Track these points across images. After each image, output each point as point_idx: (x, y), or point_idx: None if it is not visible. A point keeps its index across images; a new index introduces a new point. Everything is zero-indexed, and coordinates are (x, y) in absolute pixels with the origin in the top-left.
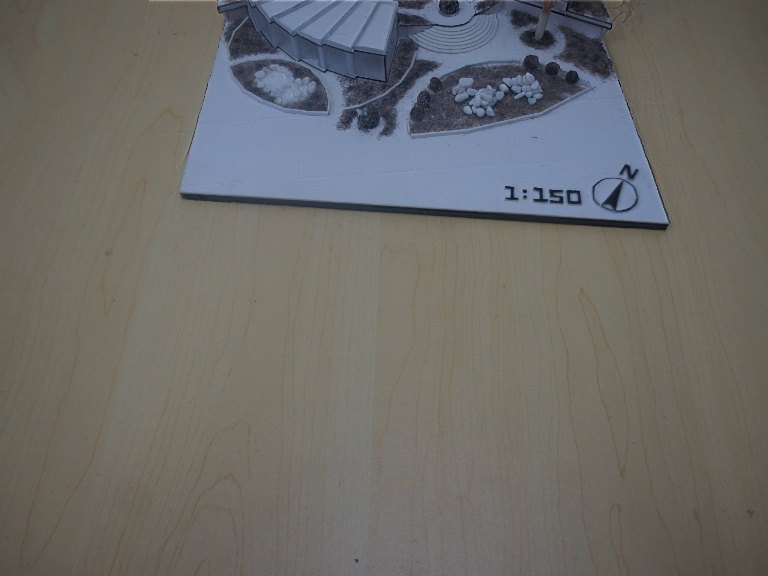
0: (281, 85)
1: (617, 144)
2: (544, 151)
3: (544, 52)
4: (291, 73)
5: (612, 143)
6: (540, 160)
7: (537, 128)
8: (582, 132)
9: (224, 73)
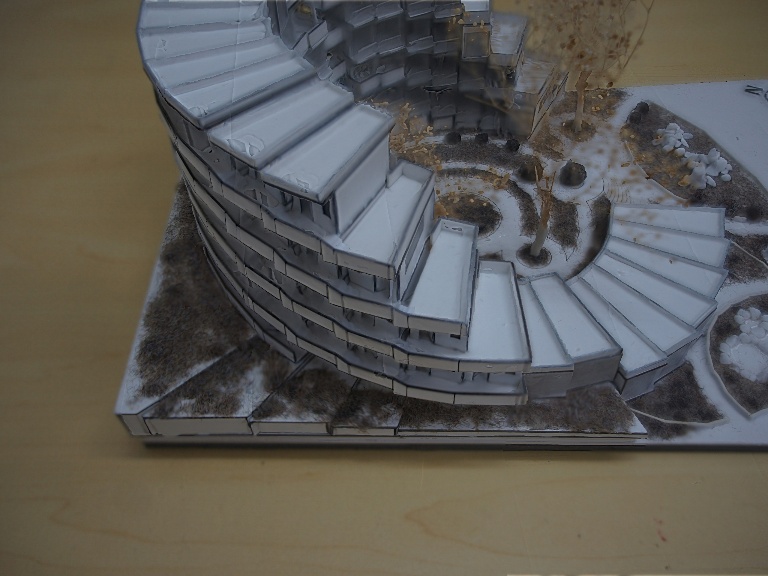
0: (767, 344)
1: (719, 94)
2: (753, 134)
3: (599, 127)
4: (735, 336)
5: (719, 96)
6: (767, 137)
7: (722, 137)
8: (713, 111)
9: (760, 426)
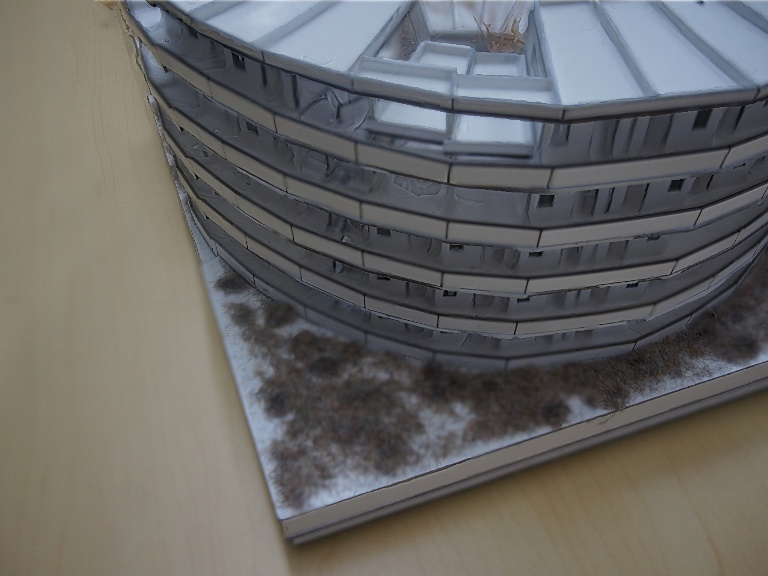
0: None
1: None
2: None
3: None
4: None
5: None
6: None
7: None
8: None
9: None
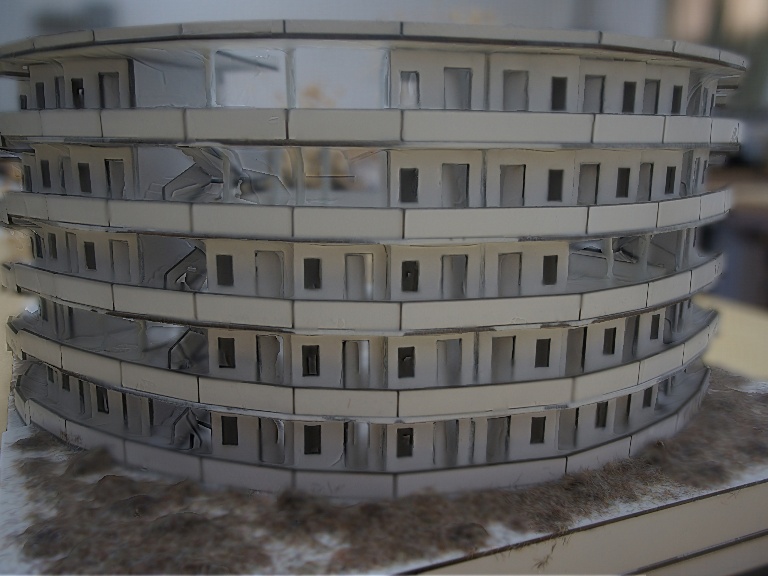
0: None
1: None
2: None
3: None
4: None
5: None
6: None
7: None
8: None
9: None
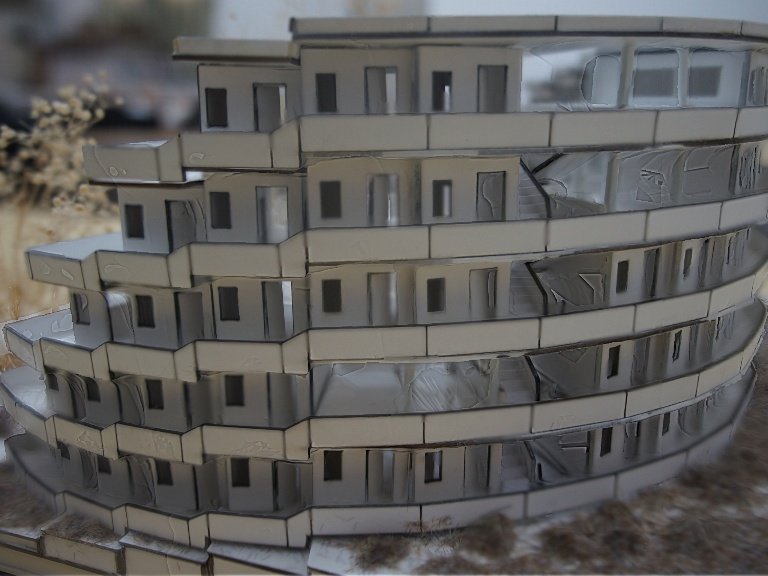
0: None
1: None
2: None
3: (5, 455)
4: None
5: None
6: None
7: None
8: None
9: None
